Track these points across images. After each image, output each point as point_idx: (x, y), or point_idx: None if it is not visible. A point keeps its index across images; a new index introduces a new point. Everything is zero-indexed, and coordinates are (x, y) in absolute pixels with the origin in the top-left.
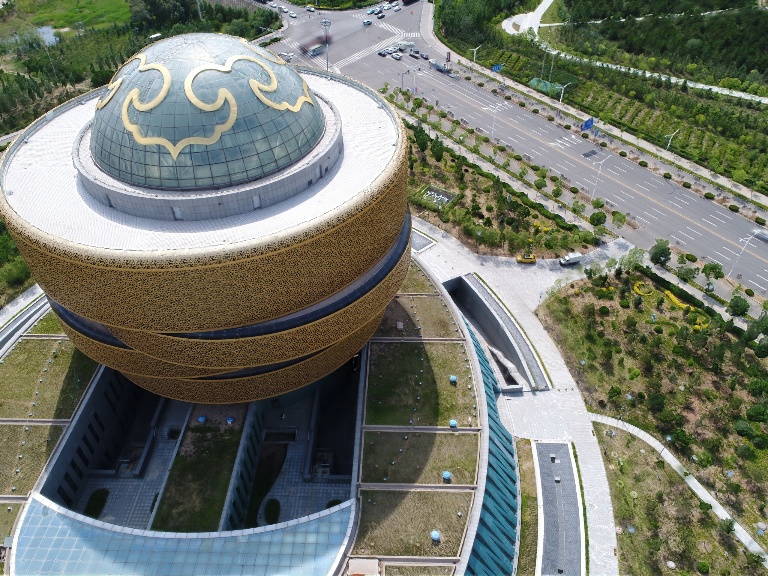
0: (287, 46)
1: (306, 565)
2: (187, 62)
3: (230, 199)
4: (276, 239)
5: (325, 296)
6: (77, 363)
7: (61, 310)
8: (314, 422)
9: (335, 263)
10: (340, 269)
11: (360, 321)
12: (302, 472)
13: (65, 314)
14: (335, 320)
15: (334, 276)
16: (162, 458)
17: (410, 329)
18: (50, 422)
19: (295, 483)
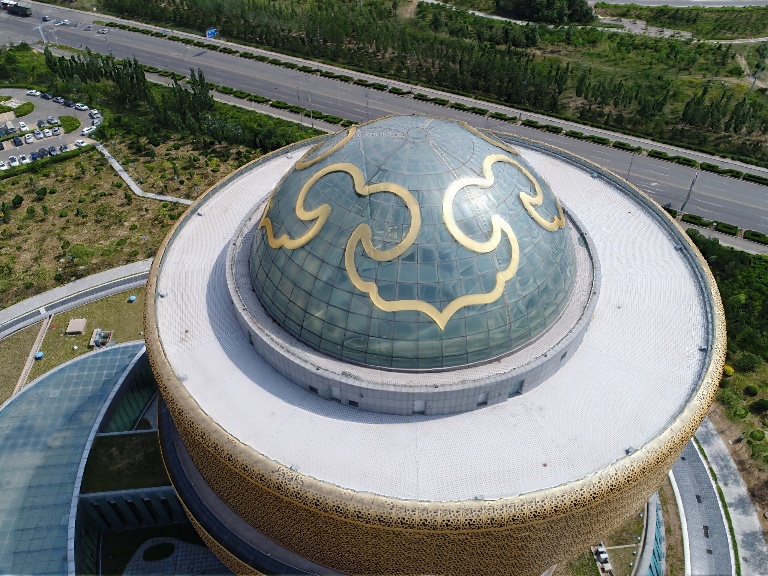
0: None
1: None
2: (359, 152)
3: None
4: (166, 380)
5: None
6: None
7: None
8: None
9: None
10: None
11: None
12: (205, 573)
13: None
14: None
15: None
16: None
17: None
18: None
19: (192, 568)
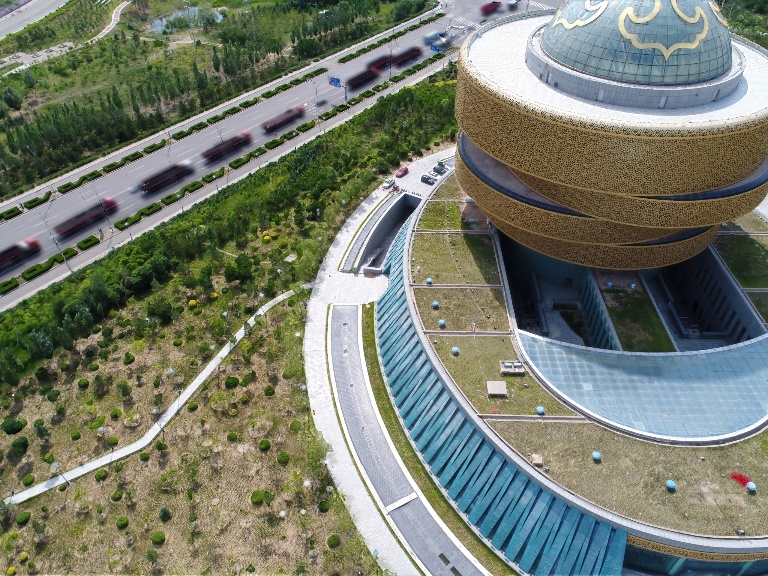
0: (454, 20)
1: (764, 371)
2: None
3: (704, 91)
4: (757, 117)
5: (750, 173)
6: (475, 249)
7: (509, 193)
8: (671, 296)
9: (766, 145)
10: (765, 151)
11: (763, 197)
12: (675, 332)
13: (515, 196)
14: (759, 191)
15: (760, 157)
16: (555, 323)
17: (731, 226)
18: (487, 287)
19: (674, 339)
